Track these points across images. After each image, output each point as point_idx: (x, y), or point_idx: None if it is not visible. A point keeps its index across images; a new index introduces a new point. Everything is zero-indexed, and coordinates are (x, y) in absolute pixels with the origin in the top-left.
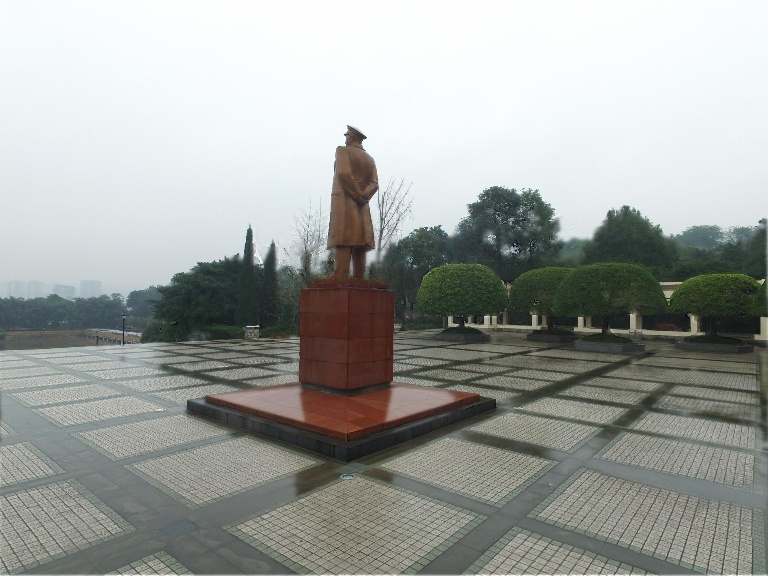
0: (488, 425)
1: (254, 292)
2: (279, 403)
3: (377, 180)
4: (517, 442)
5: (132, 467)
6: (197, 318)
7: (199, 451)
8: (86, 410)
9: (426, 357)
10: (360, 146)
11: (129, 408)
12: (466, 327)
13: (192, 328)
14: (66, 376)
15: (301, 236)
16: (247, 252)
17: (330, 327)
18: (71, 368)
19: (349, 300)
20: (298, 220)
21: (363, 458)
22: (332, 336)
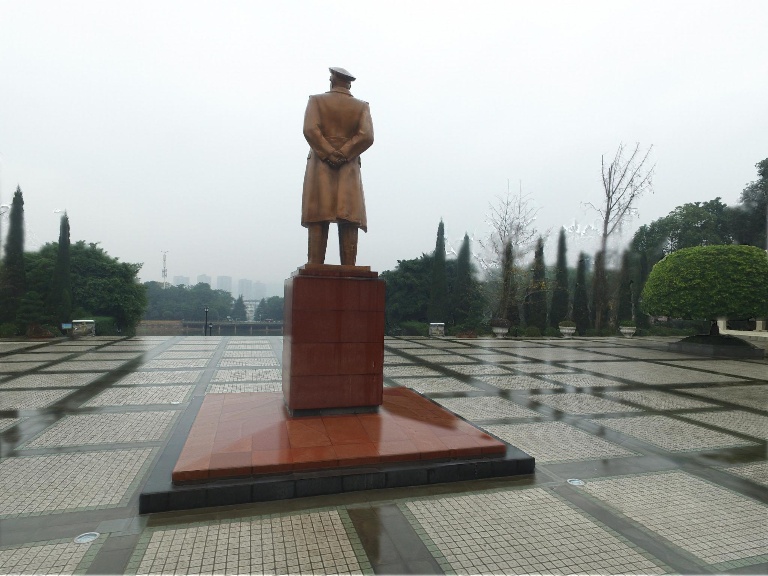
0: (449, 503)
1: (445, 288)
2: (224, 414)
3: (364, 131)
4: (422, 554)
5: (1, 461)
6: (395, 314)
7: (80, 456)
8: (132, 394)
9: (597, 374)
10: (342, 90)
11: (160, 397)
12: (724, 335)
13: (389, 323)
14: (202, 361)
15: (495, 226)
16: (438, 247)
17: (288, 327)
18: (224, 354)
19: (294, 292)
20: (494, 209)
21: (170, 513)
22: (288, 338)
